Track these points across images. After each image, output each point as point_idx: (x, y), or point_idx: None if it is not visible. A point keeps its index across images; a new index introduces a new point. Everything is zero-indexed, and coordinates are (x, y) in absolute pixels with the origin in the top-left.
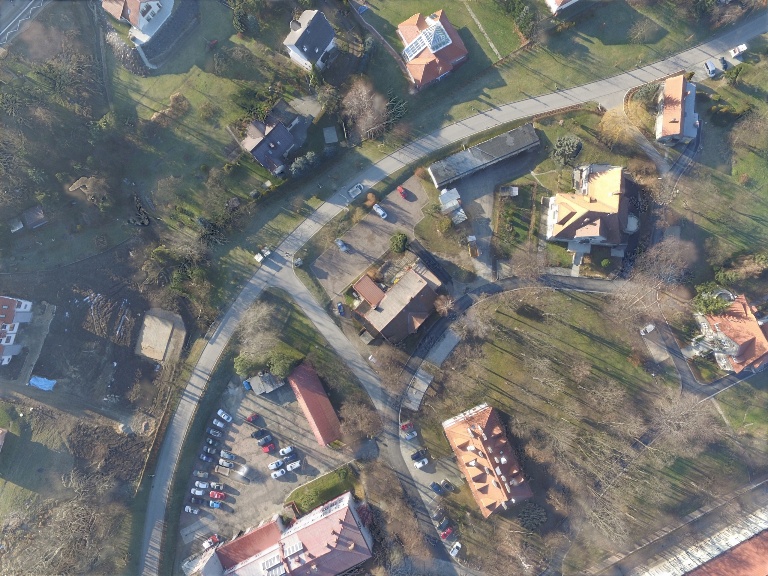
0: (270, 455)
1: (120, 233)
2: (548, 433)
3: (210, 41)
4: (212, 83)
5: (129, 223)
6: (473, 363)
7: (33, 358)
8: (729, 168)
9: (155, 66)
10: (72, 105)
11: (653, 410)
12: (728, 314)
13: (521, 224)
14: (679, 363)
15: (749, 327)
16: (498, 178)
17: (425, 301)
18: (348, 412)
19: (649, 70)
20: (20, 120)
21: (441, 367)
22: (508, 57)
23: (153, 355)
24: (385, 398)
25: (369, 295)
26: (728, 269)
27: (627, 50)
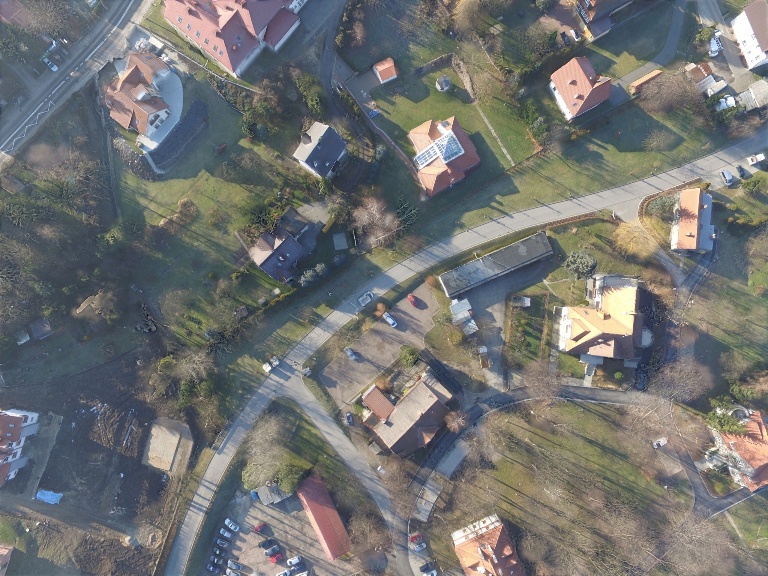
0: (277, 565)
1: (127, 340)
2: (559, 545)
3: (219, 146)
4: (220, 188)
5: (136, 330)
6: (483, 474)
7: (39, 470)
8: (745, 278)
9: (163, 171)
10: (79, 213)
11: (665, 523)
12: (743, 434)
13: (533, 333)
14: (692, 476)
15: (765, 450)
16: (510, 286)
17: (435, 416)
18: (356, 524)
19: (664, 177)
20: (27, 236)
21: (451, 478)
22: (521, 163)
23: (160, 465)
24: (394, 509)
25: (379, 408)
26: (743, 384)
27: (642, 157)
